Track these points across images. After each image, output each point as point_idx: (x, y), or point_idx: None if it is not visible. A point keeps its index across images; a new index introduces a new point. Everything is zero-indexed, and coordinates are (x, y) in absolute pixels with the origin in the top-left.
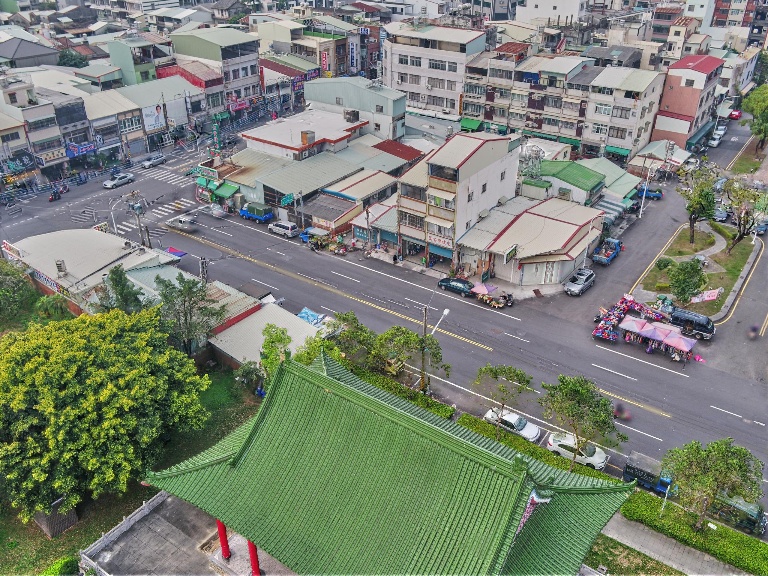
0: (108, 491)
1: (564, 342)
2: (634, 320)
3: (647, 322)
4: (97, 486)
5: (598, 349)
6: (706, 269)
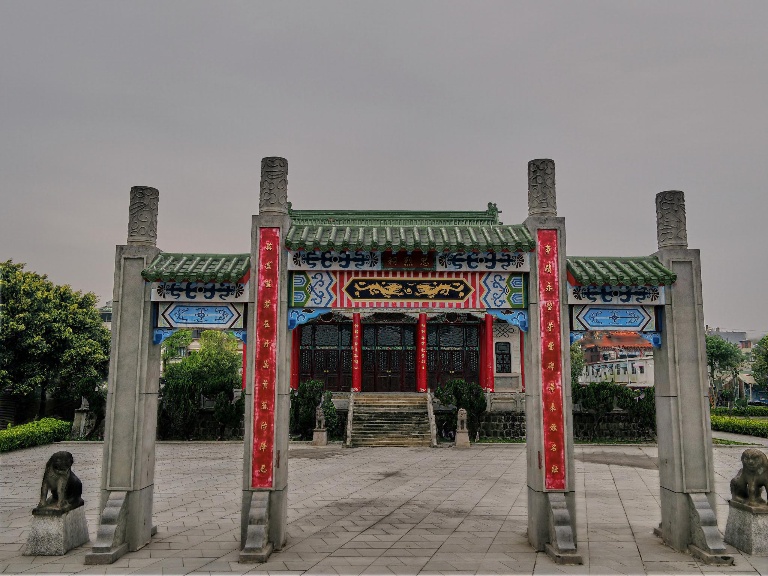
0: (59, 395)
1: None
2: None
3: None
4: (65, 366)
5: None
6: None
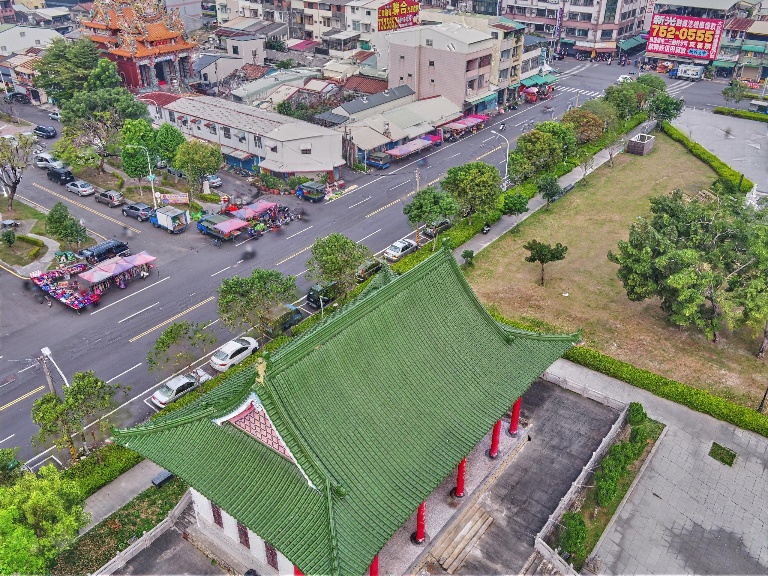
0: None
1: (70, 333)
2: (95, 271)
3: (100, 267)
4: None
5: (97, 314)
6: (24, 227)
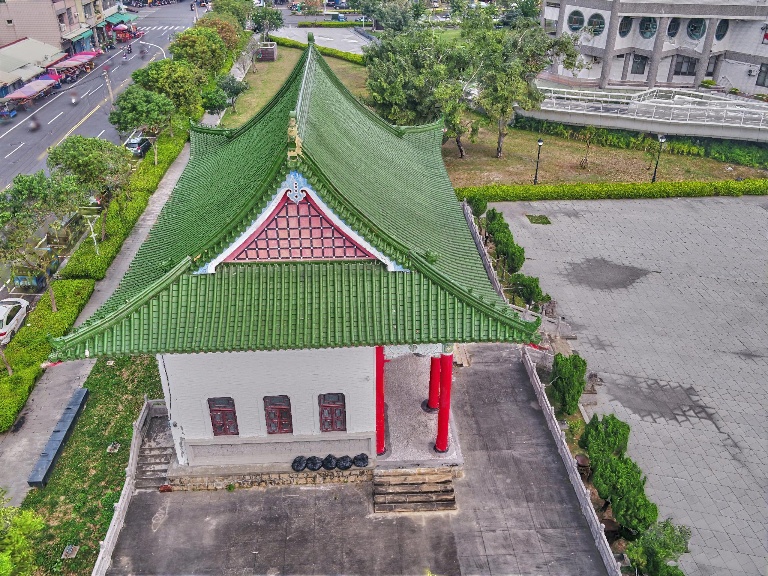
0: None
1: None
2: None
3: None
4: None
5: None
6: None
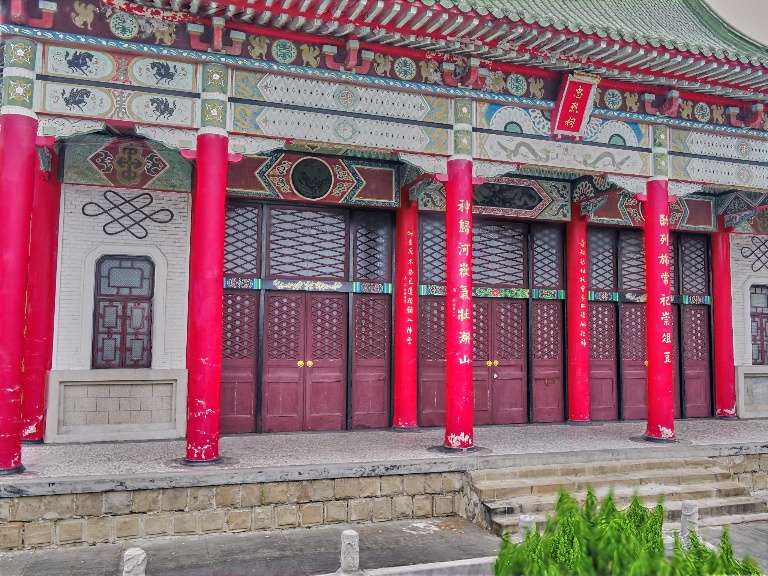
0: None
1: None
2: None
3: None
4: None
5: None
6: None
